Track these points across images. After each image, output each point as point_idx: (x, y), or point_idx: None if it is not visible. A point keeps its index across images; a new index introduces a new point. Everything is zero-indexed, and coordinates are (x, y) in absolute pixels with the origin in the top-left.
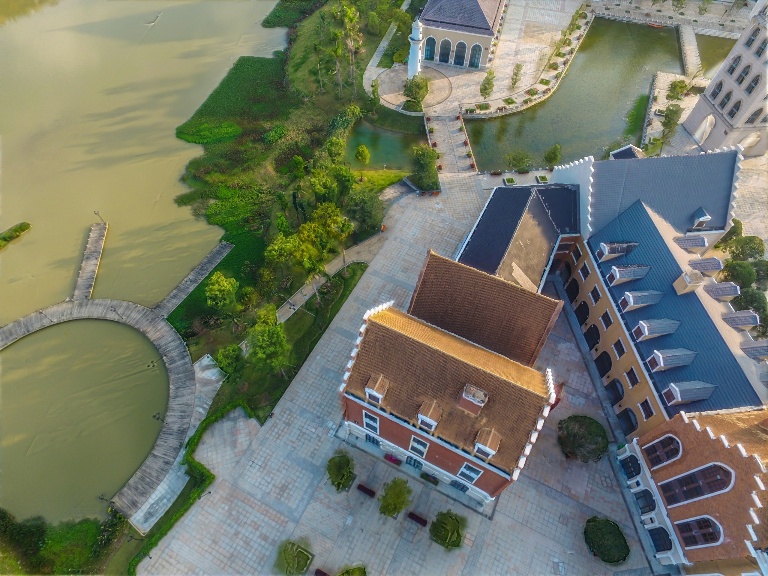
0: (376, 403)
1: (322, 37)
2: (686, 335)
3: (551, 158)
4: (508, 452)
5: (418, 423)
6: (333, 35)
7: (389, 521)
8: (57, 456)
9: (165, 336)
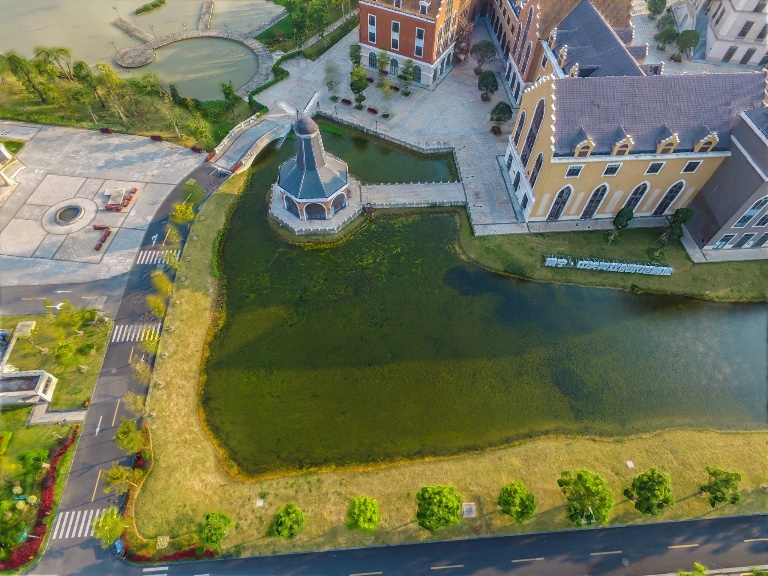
0: (375, 2)
1: None
2: None
3: None
4: (434, 8)
5: (394, 6)
6: None
7: (380, 90)
8: (199, 84)
9: (254, 44)
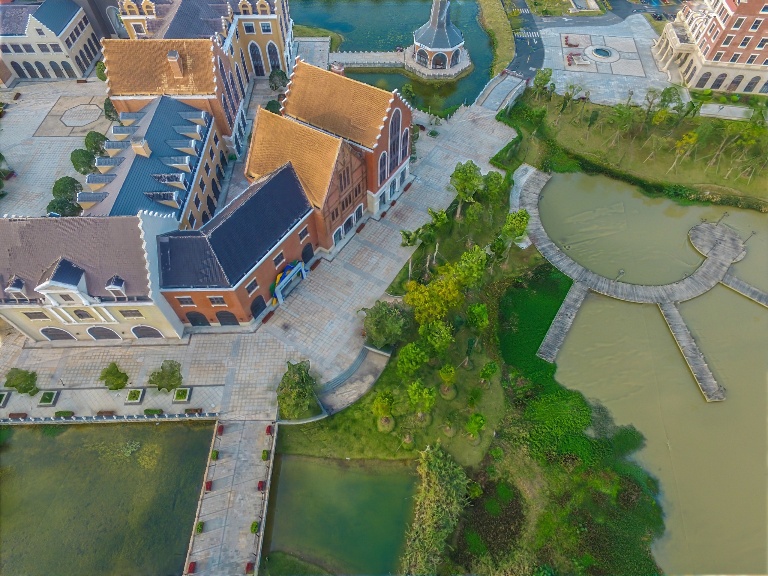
0: None
1: None
2: (169, 135)
3: (121, 373)
4: None
5: None
6: None
7: None
8: None
9: (567, 266)
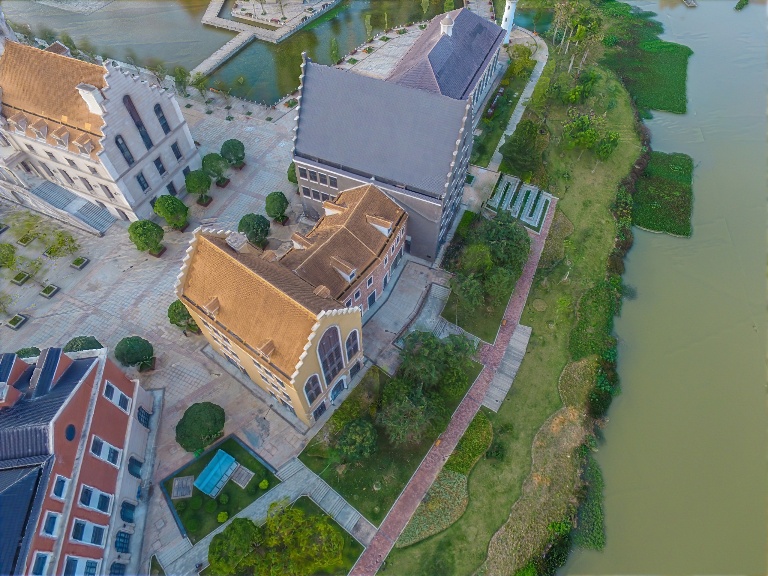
0: None
1: (602, 100)
2: None
3: None
4: None
5: None
6: (587, 15)
7: None
8: None
9: None
